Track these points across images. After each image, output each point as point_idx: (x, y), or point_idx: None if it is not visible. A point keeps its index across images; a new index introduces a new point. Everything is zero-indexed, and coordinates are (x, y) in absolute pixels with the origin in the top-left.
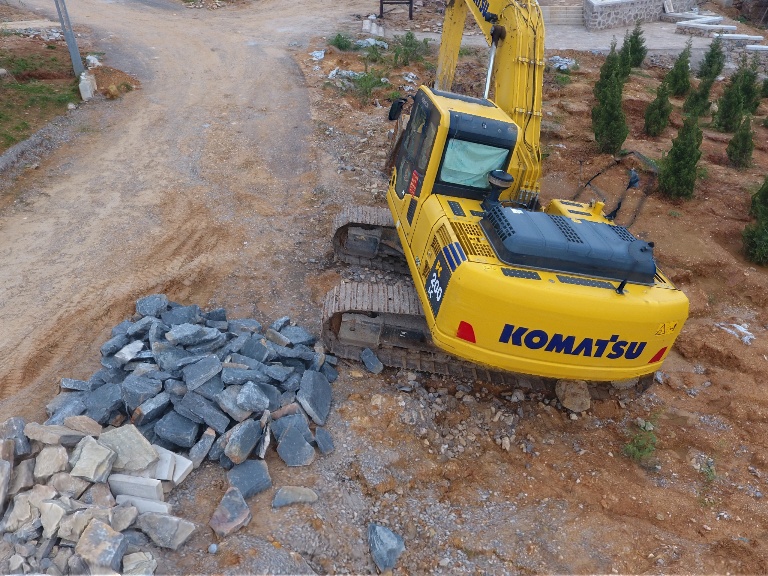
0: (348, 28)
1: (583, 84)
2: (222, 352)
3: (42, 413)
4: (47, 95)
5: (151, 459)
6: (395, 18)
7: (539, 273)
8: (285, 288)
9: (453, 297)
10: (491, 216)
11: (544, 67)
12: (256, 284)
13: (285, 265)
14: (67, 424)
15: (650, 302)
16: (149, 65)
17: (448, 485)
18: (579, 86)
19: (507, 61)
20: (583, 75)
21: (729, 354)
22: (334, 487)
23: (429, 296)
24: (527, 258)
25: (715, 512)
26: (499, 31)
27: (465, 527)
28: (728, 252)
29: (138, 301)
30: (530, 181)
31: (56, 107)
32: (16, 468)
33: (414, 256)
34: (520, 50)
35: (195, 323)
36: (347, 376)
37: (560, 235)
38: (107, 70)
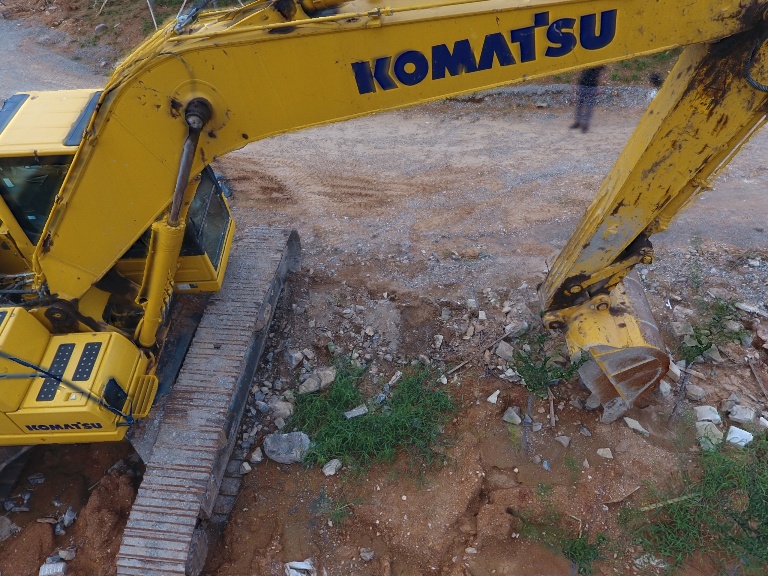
0: None
1: None
2: None
3: None
4: None
5: None
6: None
7: None
8: None
9: None
10: None
11: (90, 141)
12: None
13: None
14: None
15: None
16: None
17: None
18: None
19: None
20: None
21: None
22: None
23: None
24: None
25: None
26: None
27: None
28: None
29: None
30: None
31: None
32: None
33: None
34: None
35: None
36: None
37: None
38: None
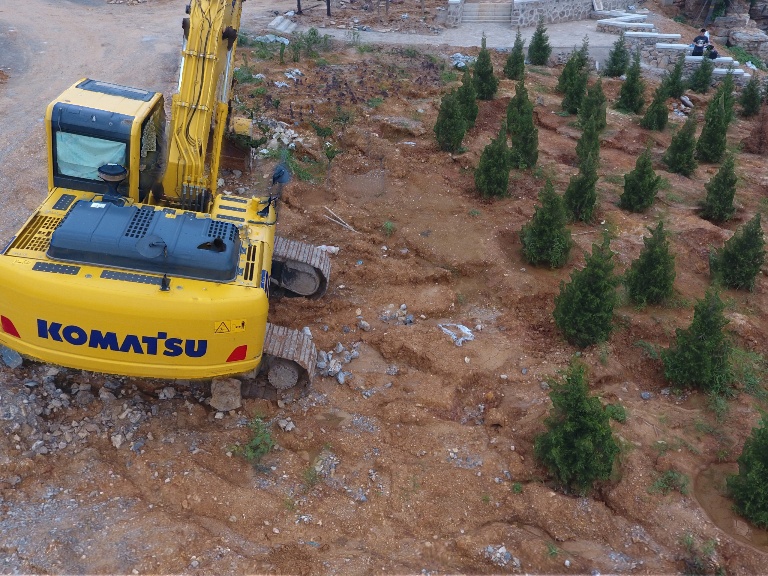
0: (255, 24)
1: None
2: None
3: None
4: None
5: None
6: (316, 15)
7: (82, 268)
8: None
9: None
10: None
11: (217, 61)
12: None
13: None
14: None
15: (200, 299)
16: (29, 60)
17: (18, 481)
18: None
19: None
20: None
21: (422, 355)
22: None
23: None
24: (71, 253)
25: (298, 515)
26: (189, 24)
27: (1, 524)
28: (503, 252)
29: None
30: (192, 176)
31: None
32: None
33: None
34: (188, 43)
35: None
36: None
37: (120, 230)
38: None
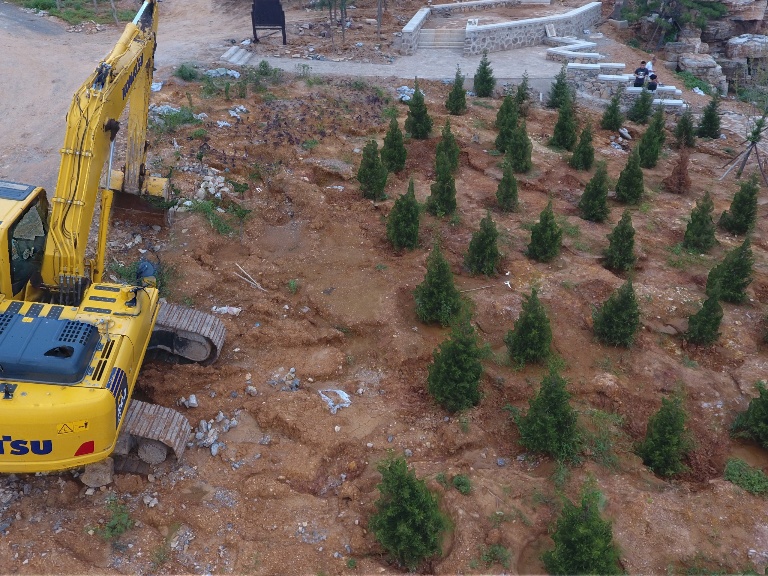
0: (209, 56)
1: None
2: None
3: None
4: None
5: None
6: (273, 42)
7: None
8: None
9: None
10: None
11: (93, 157)
12: None
13: None
14: None
15: (41, 405)
16: None
17: None
18: (402, 121)
19: None
20: None
21: (293, 426)
22: None
23: None
24: None
25: None
26: None
27: None
28: (398, 311)
29: None
30: (68, 267)
31: None
32: None
33: None
34: (65, 142)
35: None
36: None
37: None
38: None
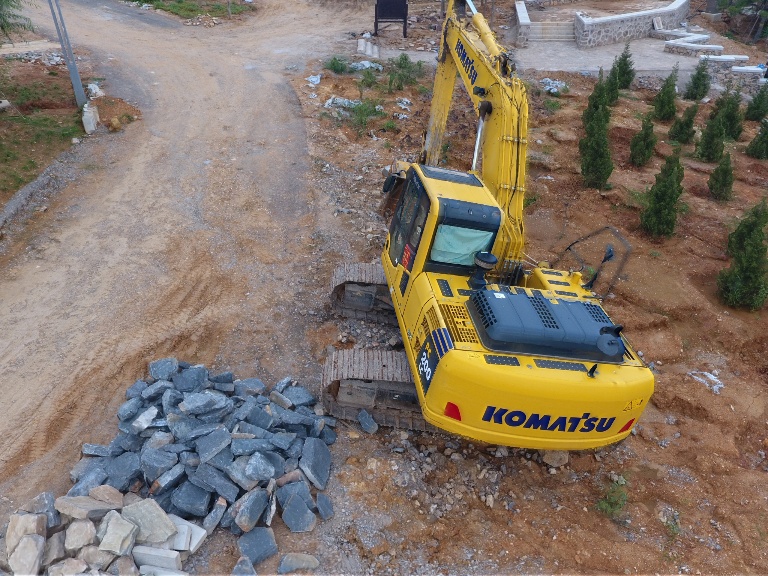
0: (343, 49)
1: (572, 110)
2: (230, 418)
3: (66, 478)
4: (51, 128)
5: (170, 533)
6: (389, 35)
7: (518, 358)
8: (286, 343)
9: (441, 381)
10: (476, 301)
11: None
12: (259, 339)
13: (286, 318)
14: (92, 495)
15: (618, 383)
16: (149, 92)
17: (437, 545)
18: (568, 112)
19: (493, 136)
20: (573, 98)
21: (698, 406)
22: (334, 552)
23: (419, 372)
24: (507, 345)
25: (678, 566)
26: (486, 107)
27: None
28: (703, 296)
29: (151, 365)
30: (514, 252)
31: (61, 142)
32: (49, 540)
33: (406, 327)
34: (505, 129)
35: (204, 388)
36: (345, 438)
37: (538, 321)
38: (109, 101)
